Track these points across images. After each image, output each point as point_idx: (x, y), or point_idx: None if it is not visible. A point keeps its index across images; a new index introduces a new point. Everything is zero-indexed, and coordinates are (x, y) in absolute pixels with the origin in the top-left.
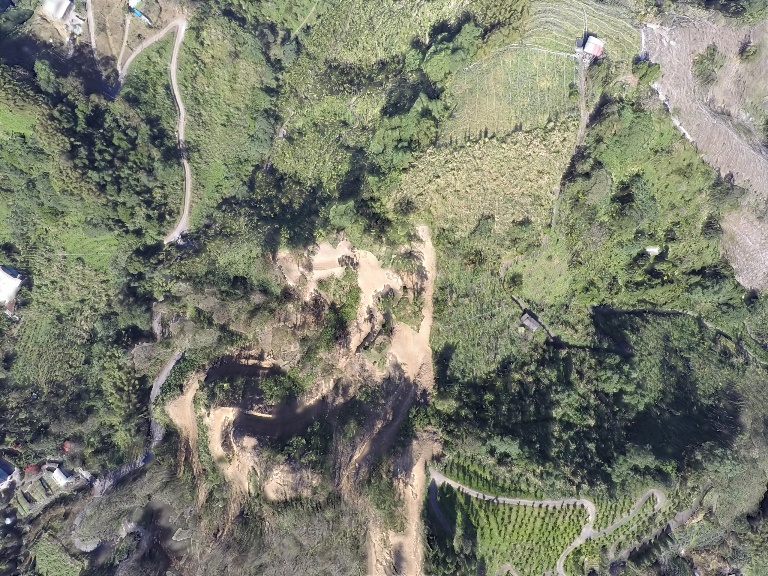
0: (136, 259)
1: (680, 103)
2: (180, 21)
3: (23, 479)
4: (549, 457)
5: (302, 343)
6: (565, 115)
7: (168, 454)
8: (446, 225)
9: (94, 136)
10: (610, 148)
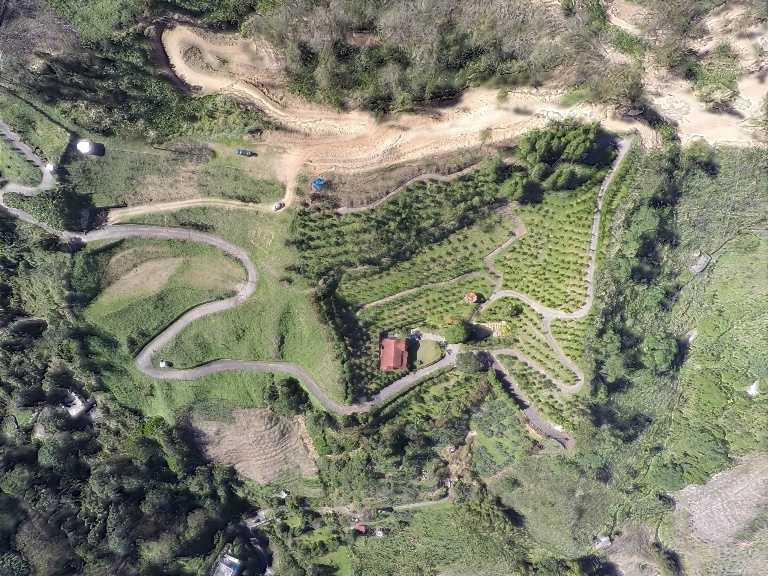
0: None
1: None
2: None
3: None
4: None
5: None
6: None
7: None
8: None
9: None
10: None
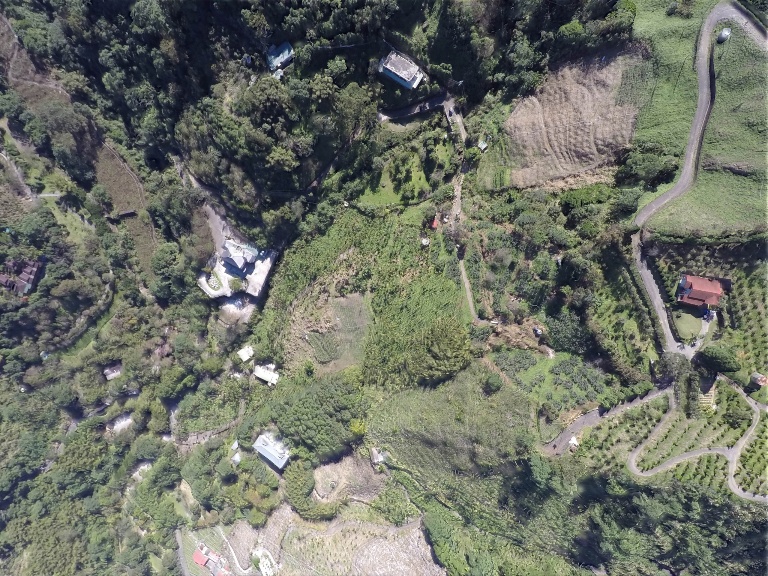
0: None
1: None
2: None
3: None
4: (764, 529)
5: None
6: None
7: None
8: None
9: None
10: None
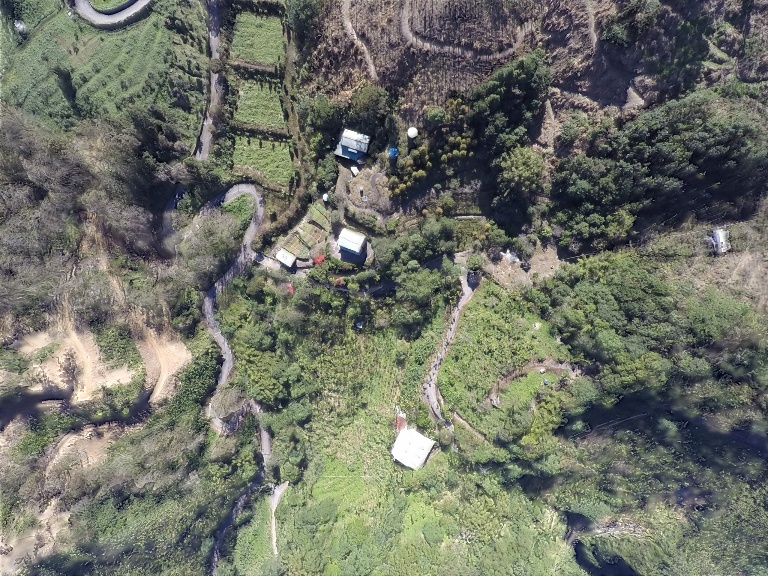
0: (286, 479)
1: None
2: None
3: None
4: None
5: (2, 489)
6: None
7: None
8: None
9: None
10: None
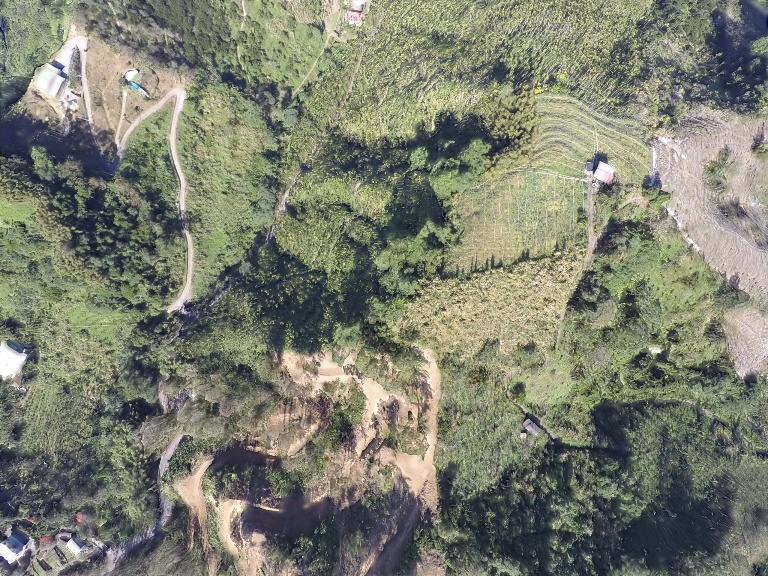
0: (140, 333)
1: (689, 215)
2: (178, 90)
3: (38, 548)
4: (548, 574)
5: (308, 452)
6: (573, 242)
7: (178, 529)
8: (451, 350)
9: (95, 218)
10: (617, 275)
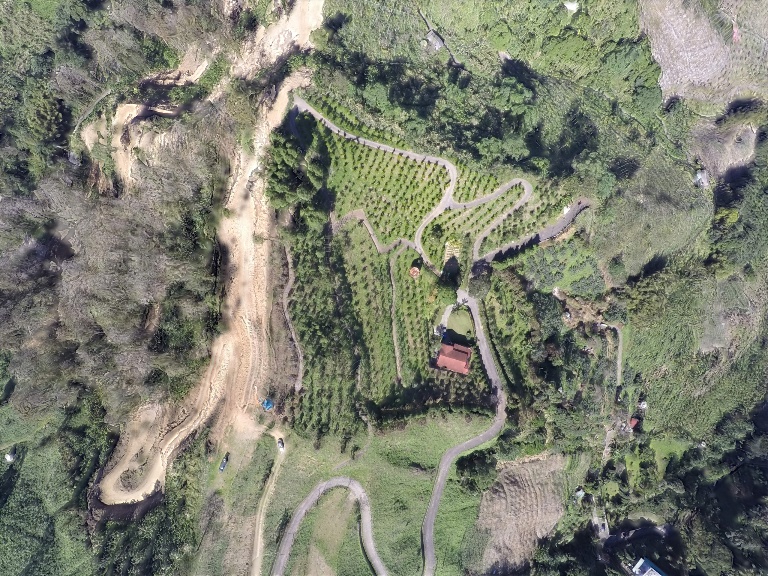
0: (80, 4)
1: None
2: None
3: None
4: None
5: (204, 19)
6: None
7: (78, 177)
8: None
9: None
10: None
